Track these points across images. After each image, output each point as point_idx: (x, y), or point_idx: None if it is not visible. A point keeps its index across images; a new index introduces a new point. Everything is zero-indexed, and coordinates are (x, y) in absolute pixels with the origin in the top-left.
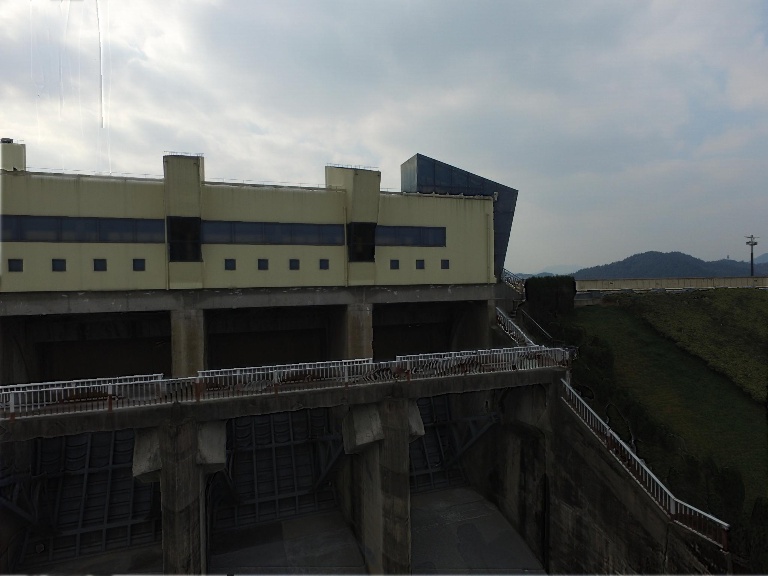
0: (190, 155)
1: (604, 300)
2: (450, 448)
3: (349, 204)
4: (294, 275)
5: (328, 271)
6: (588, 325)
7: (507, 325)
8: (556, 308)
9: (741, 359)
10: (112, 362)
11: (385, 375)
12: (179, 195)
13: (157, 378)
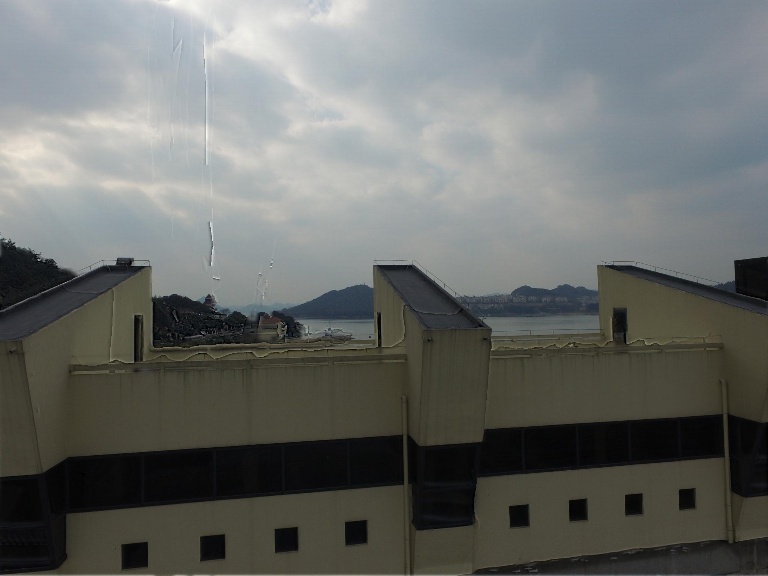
0: (394, 264)
1: None
2: None
3: (747, 381)
4: (633, 526)
5: (694, 512)
6: None
7: None
8: None
9: None
10: None
11: None
12: (447, 403)
13: None
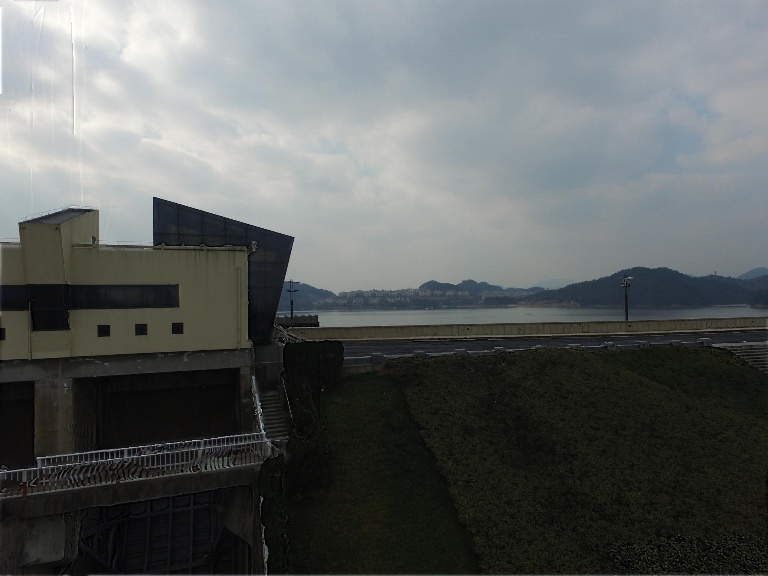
0: None
1: (385, 366)
2: None
3: None
4: None
5: (4, 342)
6: (345, 401)
7: (254, 399)
8: (319, 378)
9: (480, 456)
10: None
11: None
12: None
13: None
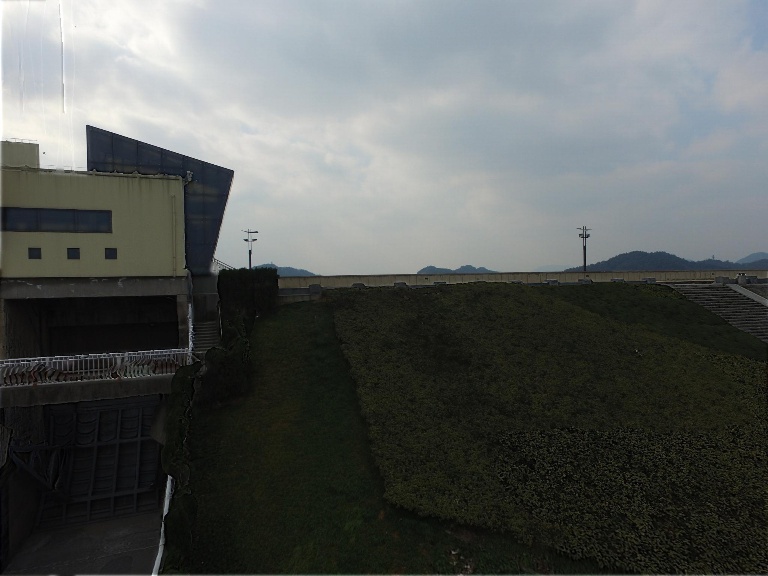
0: None
1: (321, 296)
2: None
3: None
4: None
5: None
6: (277, 324)
7: None
8: (254, 305)
9: (394, 364)
10: None
11: None
12: None
13: None
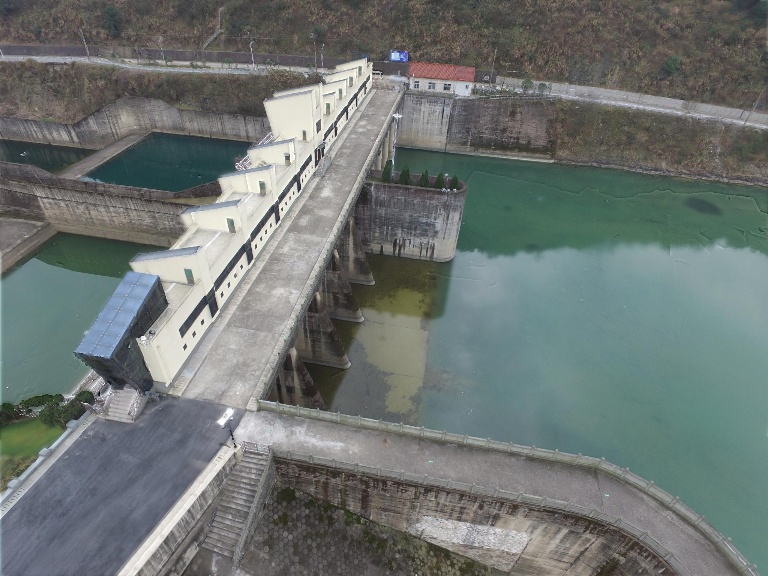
0: None
1: None
2: None
3: None
4: None
5: None
6: (55, 434)
7: None
8: None
9: None
10: None
11: None
12: None
13: None
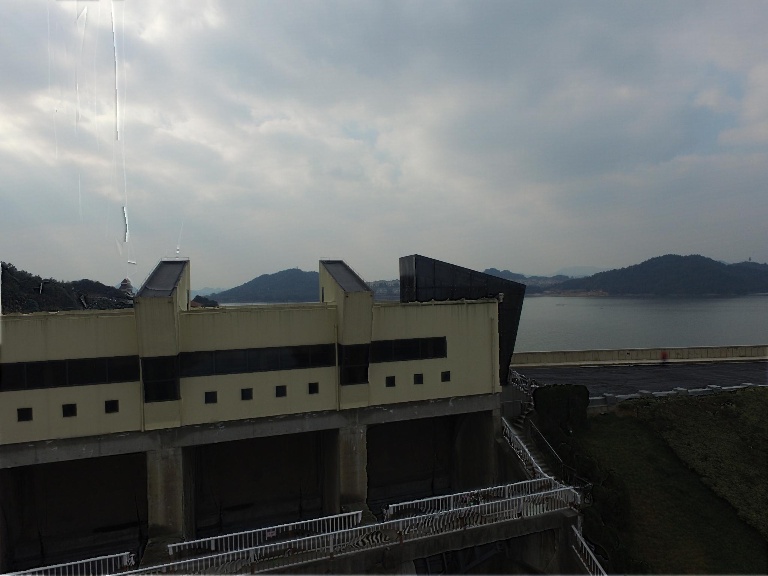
0: (174, 260)
1: (620, 407)
2: (453, 560)
3: (340, 324)
4: (281, 402)
5: (318, 395)
6: (602, 444)
7: (513, 441)
8: (567, 420)
9: None
10: (95, 473)
11: (375, 539)
12: (153, 335)
13: (122, 558)
